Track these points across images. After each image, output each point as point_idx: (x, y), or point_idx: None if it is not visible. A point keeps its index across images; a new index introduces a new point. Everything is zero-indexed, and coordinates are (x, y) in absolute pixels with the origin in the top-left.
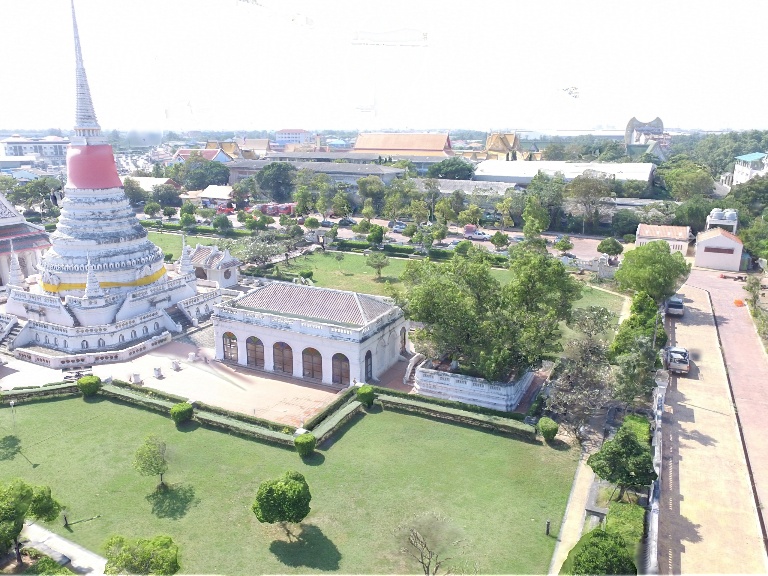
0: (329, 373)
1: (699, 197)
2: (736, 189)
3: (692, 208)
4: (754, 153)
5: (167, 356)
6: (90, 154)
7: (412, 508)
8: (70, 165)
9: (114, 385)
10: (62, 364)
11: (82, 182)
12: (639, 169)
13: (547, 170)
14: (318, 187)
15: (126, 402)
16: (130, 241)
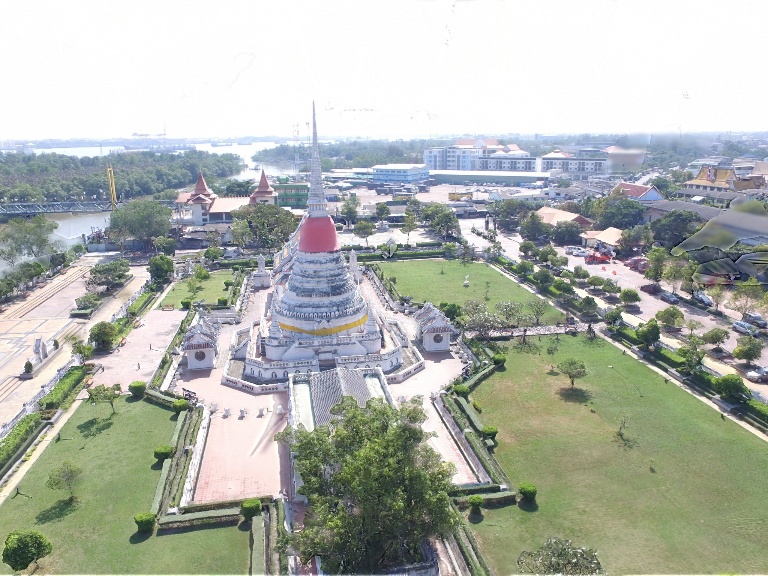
0: None
1: None
2: None
3: None
4: None
5: (277, 401)
6: (309, 224)
7: None
8: None
9: None
10: (227, 381)
11: (302, 245)
12: None
13: None
14: None
15: None
16: (322, 297)
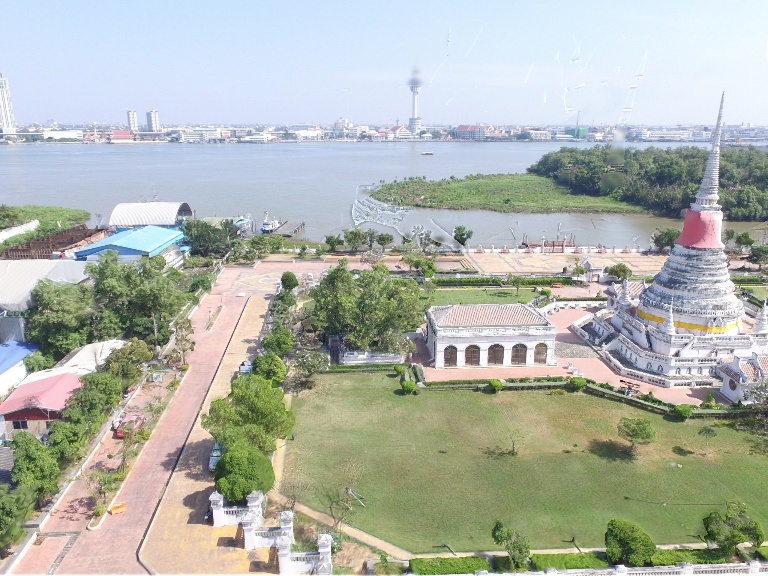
0: None
1: None
2: None
3: None
4: None
5: None
6: None
7: None
8: None
9: None
10: None
11: None
12: None
13: None
14: None
15: None
16: None
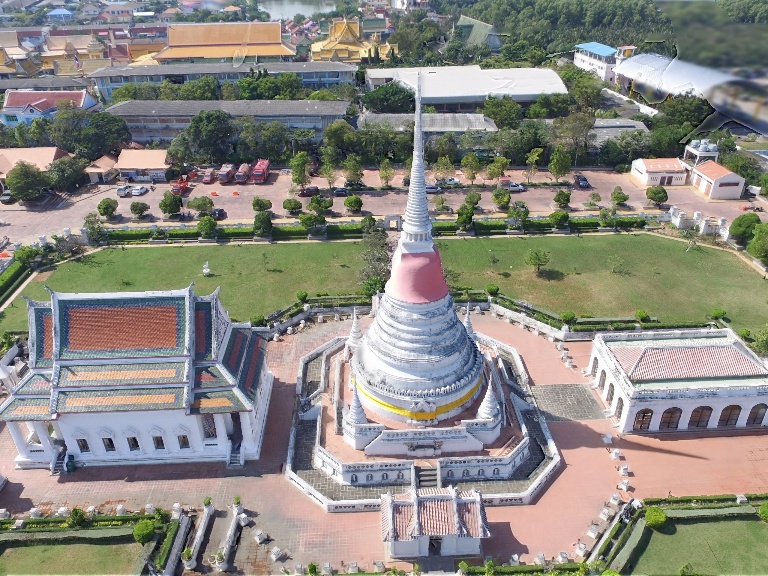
0: (745, 419)
1: (674, 128)
2: (672, 109)
3: (671, 139)
4: (593, 43)
5: (581, 445)
6: (437, 260)
7: None
8: (417, 277)
9: (650, 505)
10: (531, 496)
11: (431, 293)
12: (552, 80)
13: (497, 94)
14: (317, 151)
15: (696, 520)
16: None
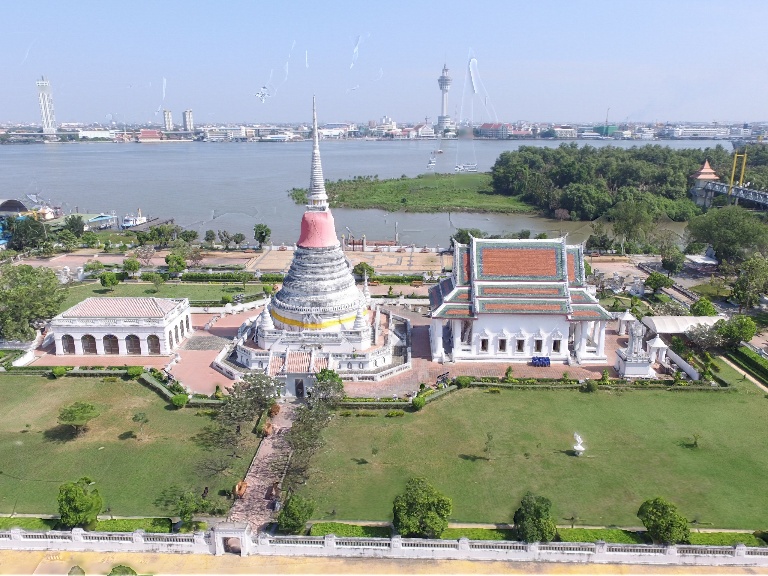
0: None
1: None
2: None
3: None
4: None
5: None
6: None
7: (70, 299)
8: None
9: None
10: None
11: None
12: None
13: None
14: None
15: None
16: None
